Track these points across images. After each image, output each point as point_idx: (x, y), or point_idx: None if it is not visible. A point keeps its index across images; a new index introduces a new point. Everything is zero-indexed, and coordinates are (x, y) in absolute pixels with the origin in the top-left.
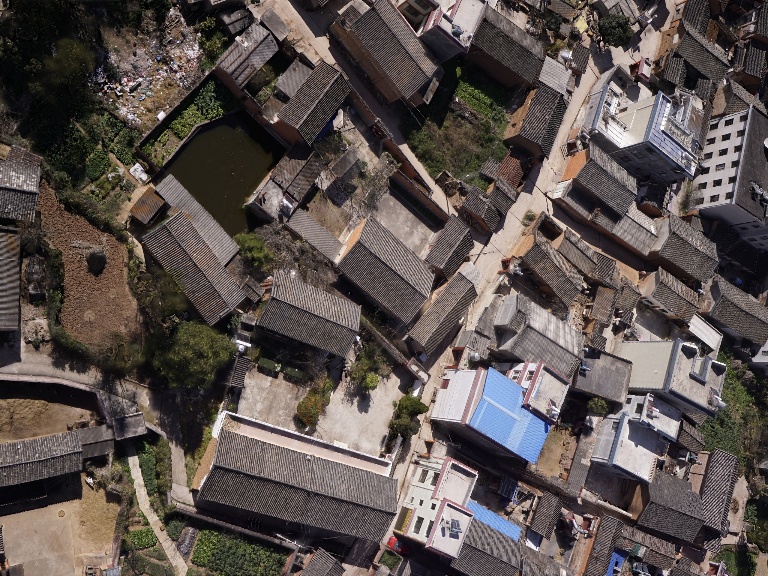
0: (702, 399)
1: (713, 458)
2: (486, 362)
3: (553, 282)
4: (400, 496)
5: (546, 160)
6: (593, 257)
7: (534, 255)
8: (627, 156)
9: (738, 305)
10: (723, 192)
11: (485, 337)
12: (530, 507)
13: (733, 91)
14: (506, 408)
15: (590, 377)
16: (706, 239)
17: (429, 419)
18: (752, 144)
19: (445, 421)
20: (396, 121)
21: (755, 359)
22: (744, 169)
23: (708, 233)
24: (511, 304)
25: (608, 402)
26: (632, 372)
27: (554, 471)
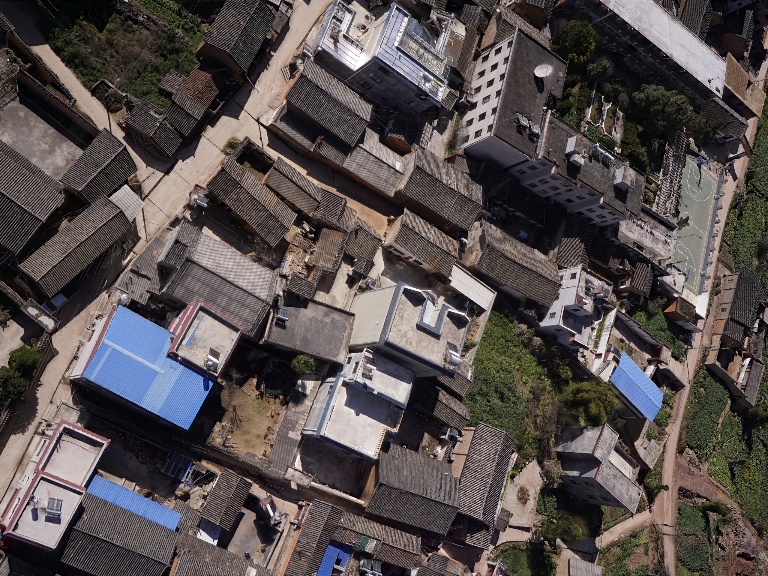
0: (435, 355)
1: (476, 434)
2: (158, 312)
3: (251, 217)
4: (15, 475)
5: (260, 82)
6: (315, 193)
7: (222, 183)
8: (366, 81)
9: (511, 257)
10: (485, 125)
11: (145, 278)
12: (210, 490)
13: (502, 16)
14: (142, 357)
15: (292, 329)
16: (469, 180)
17: (68, 379)
18: (518, 71)
19: (78, 379)
20: (33, 17)
21: (543, 323)
22: (507, 98)
23: (475, 175)
24: (174, 235)
25: (332, 365)
26: (358, 327)
27: (256, 448)
